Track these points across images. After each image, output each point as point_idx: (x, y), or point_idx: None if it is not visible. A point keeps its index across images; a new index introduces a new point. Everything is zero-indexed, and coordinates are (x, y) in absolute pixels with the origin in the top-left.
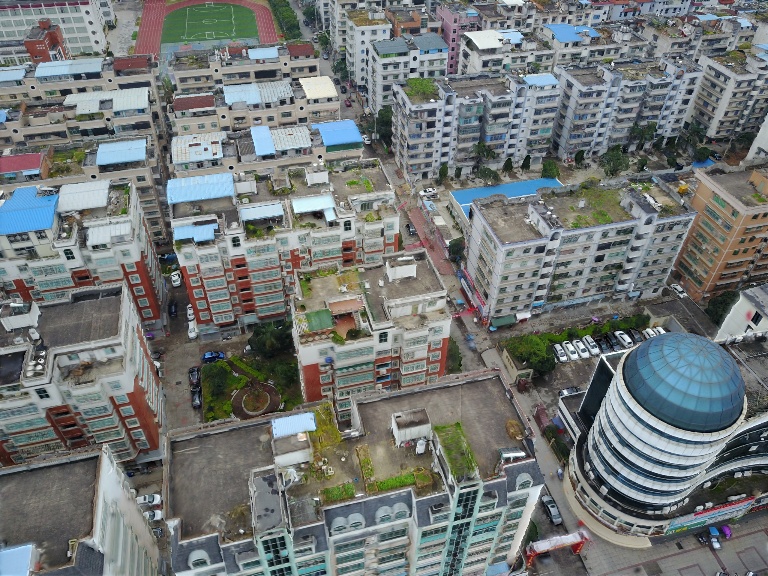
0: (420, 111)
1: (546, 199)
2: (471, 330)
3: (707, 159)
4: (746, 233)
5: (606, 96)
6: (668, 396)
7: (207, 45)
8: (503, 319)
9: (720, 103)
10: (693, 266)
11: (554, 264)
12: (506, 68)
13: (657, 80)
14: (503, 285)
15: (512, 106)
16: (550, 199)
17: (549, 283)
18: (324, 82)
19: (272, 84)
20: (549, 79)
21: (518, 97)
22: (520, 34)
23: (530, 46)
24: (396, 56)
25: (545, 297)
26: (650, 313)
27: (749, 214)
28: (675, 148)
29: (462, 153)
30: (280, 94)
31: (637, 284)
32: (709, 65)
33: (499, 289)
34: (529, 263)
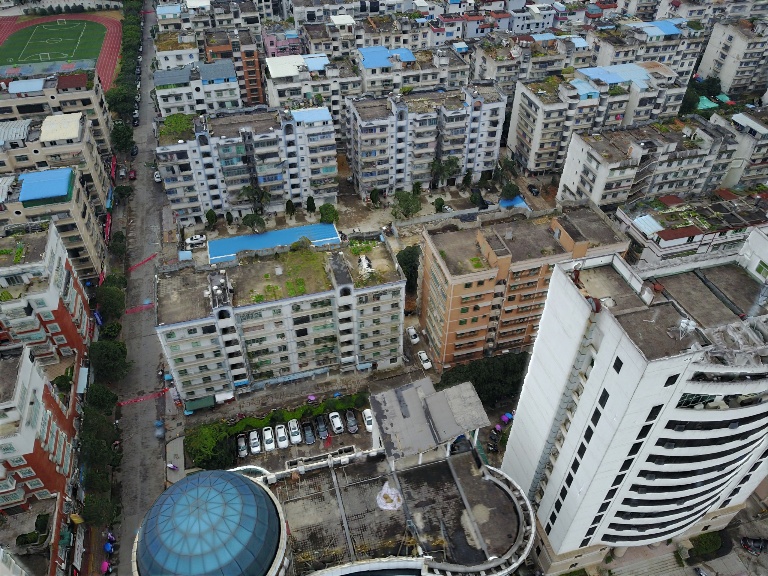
0: (168, 153)
1: (245, 264)
2: (169, 413)
3: (516, 196)
4: (464, 303)
5: (394, 131)
6: (150, 569)
7: (38, 68)
8: (200, 401)
9: (534, 134)
10: (432, 333)
11: (242, 342)
12: (308, 97)
13: (449, 112)
14: (179, 368)
15: (282, 144)
16: (250, 264)
17: (246, 361)
18: (69, 121)
19: (10, 124)
20: (321, 114)
21: (287, 135)
22: (327, 59)
23: (332, 73)
24: (175, 87)
25: (249, 375)
26: (370, 391)
27: (458, 283)
28: (492, 182)
29: (234, 196)
30: (10, 136)
31: (364, 356)
32: (523, 92)
33: (177, 372)
34: (203, 343)
